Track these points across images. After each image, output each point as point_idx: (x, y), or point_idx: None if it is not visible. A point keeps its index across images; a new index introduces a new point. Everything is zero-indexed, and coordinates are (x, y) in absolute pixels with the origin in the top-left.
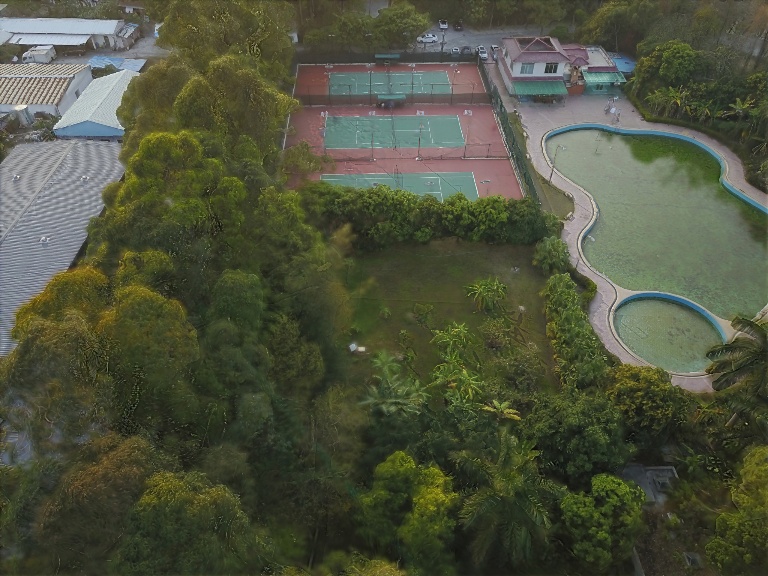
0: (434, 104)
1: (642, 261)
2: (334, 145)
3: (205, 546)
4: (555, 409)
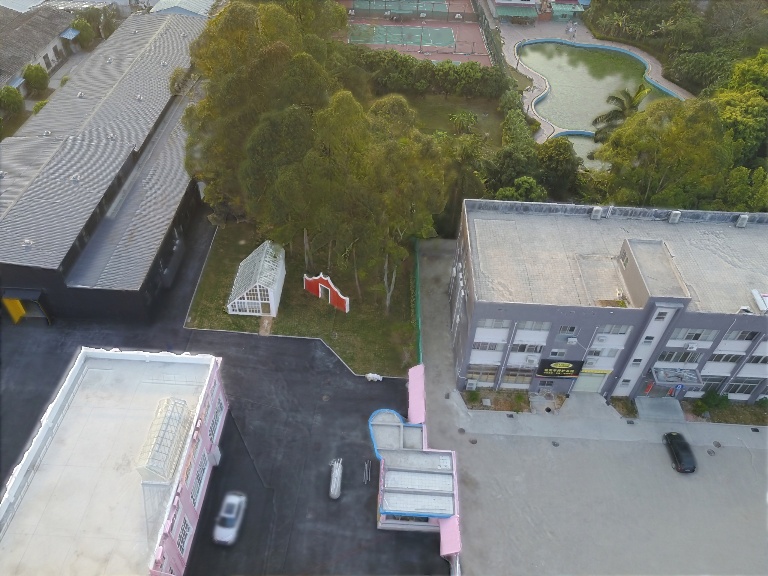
0: (434, 20)
1: (576, 117)
2: (357, 41)
3: (321, 80)
4: (498, 153)
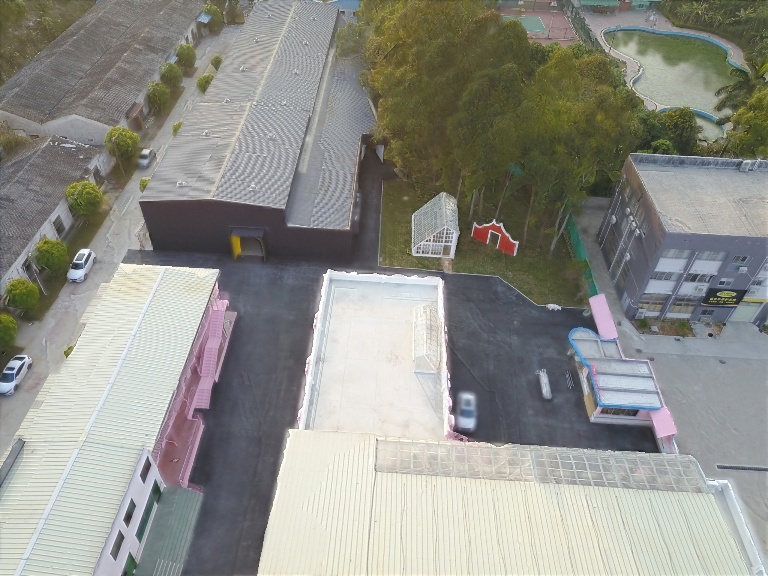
0: None
1: (673, 95)
2: None
3: None
4: None
